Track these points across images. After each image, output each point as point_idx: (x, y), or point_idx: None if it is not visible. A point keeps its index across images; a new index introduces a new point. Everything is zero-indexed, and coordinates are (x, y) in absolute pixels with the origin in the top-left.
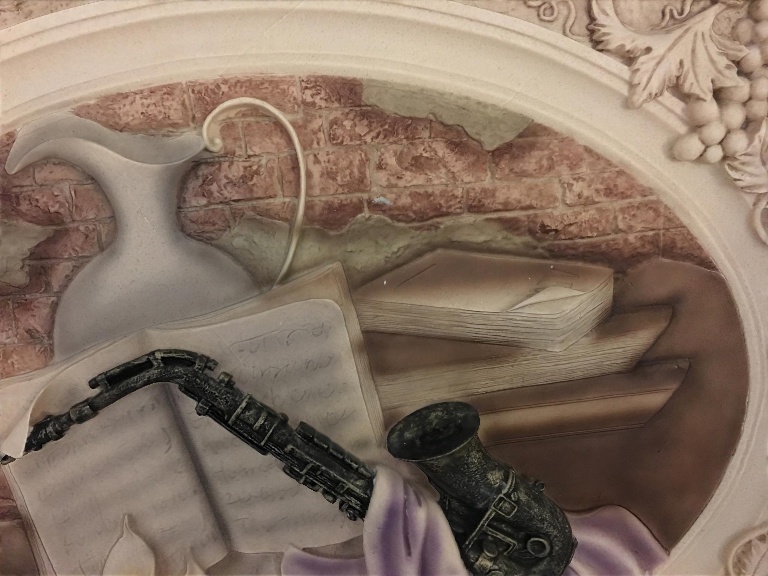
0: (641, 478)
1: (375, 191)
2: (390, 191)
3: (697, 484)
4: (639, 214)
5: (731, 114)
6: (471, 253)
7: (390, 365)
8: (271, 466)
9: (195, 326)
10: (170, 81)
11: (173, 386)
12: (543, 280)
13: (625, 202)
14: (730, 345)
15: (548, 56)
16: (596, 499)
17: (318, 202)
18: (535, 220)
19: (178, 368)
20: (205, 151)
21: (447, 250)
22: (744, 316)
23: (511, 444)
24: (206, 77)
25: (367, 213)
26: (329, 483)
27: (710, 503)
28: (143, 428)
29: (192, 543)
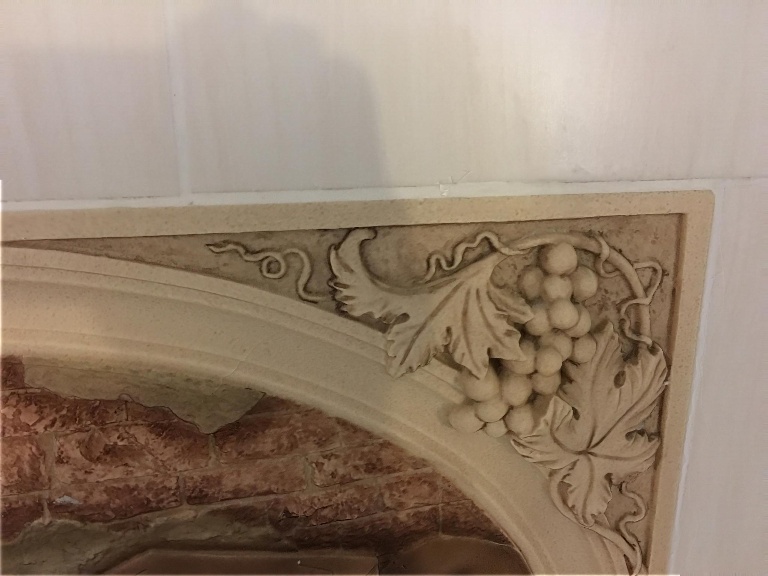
0: None
1: (58, 488)
2: (78, 487)
3: None
4: (411, 489)
5: (512, 392)
6: (194, 552)
7: None
8: None
9: None
10: None
11: None
12: None
13: (393, 476)
14: None
15: (276, 323)
16: None
17: None
18: (276, 507)
19: None
20: None
21: (162, 550)
22: None
23: None
24: None
25: (48, 516)
26: None
27: None
28: None
29: None
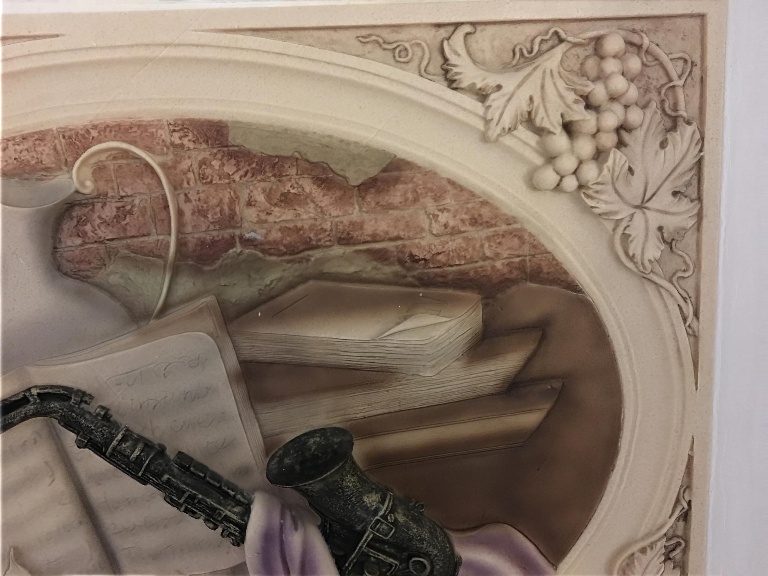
0: (524, 496)
1: (246, 227)
2: (261, 226)
3: (579, 500)
4: (505, 242)
5: (581, 146)
6: (342, 284)
7: (268, 394)
8: (154, 495)
9: (72, 362)
10: (41, 128)
11: (54, 420)
12: (412, 308)
13: (490, 231)
14: (602, 364)
15: (405, 95)
16: (481, 517)
17: (191, 239)
18: (403, 250)
19: (54, 403)
20: (77, 193)
21: (319, 281)
22: (613, 336)
23: (393, 466)
24: (76, 123)
25: (239, 248)
26: (207, 511)
27: (593, 518)
28: (25, 462)
29: (78, 573)
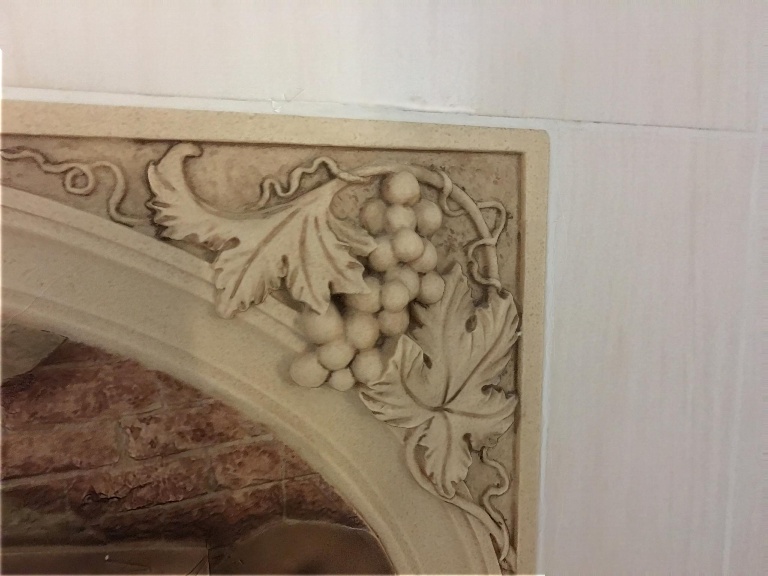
0: None
1: None
2: None
3: None
4: (248, 461)
5: (357, 330)
6: None
7: None
8: None
9: None
10: None
11: None
12: None
13: (226, 446)
14: None
15: (81, 247)
16: None
17: None
18: (79, 487)
19: None
20: None
21: None
22: None
23: None
24: None
25: None
26: None
27: None
28: None
29: None
